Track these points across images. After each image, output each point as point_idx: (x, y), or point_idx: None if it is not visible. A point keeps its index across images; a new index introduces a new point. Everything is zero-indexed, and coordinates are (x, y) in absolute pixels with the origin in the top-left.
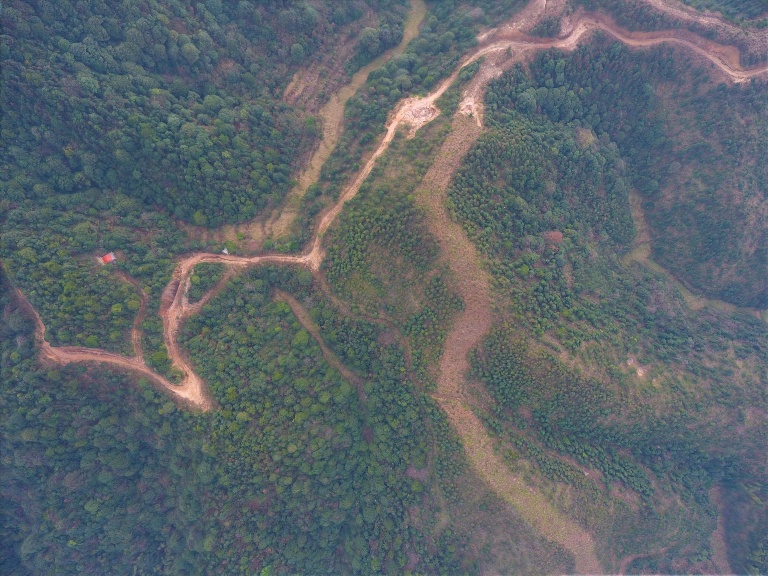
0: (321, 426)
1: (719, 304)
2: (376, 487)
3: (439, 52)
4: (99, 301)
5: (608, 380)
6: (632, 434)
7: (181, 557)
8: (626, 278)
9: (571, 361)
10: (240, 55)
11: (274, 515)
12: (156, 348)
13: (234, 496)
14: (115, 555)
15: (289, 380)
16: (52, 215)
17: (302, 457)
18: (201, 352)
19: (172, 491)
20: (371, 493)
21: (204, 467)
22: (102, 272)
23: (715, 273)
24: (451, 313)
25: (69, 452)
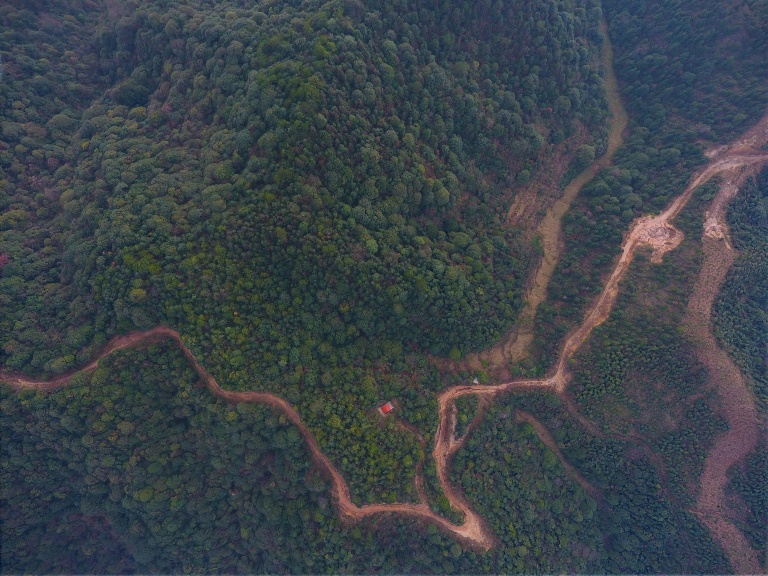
0: (577, 545)
1: None
2: None
3: (662, 167)
4: (394, 457)
5: None
6: None
7: None
8: None
9: None
10: (476, 188)
11: None
12: (437, 492)
13: None
14: None
15: (548, 504)
16: (340, 375)
17: None
18: (474, 489)
19: None
20: None
21: None
22: (390, 426)
23: None
24: (715, 434)
25: None
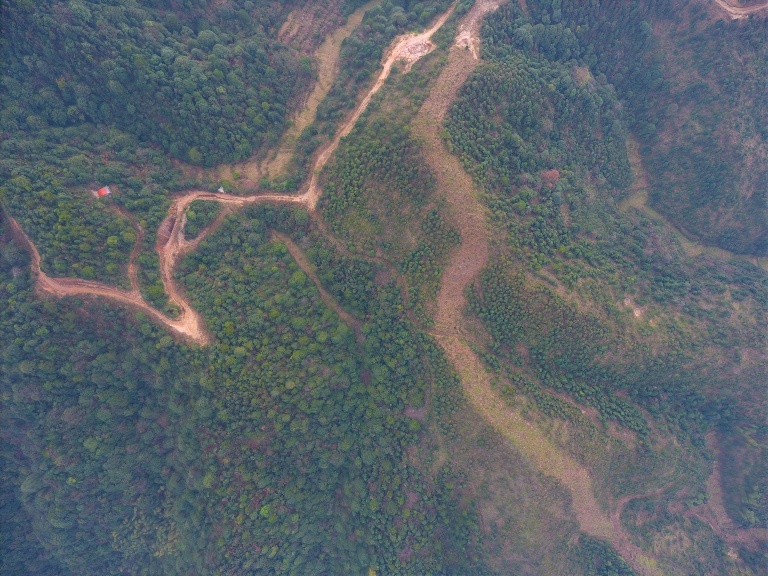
0: (319, 365)
1: (716, 251)
2: (374, 428)
3: None
4: (95, 232)
5: (605, 316)
6: (629, 374)
7: (181, 498)
8: (623, 222)
9: (568, 295)
10: None
11: (273, 454)
12: (153, 282)
13: (233, 433)
14: (115, 496)
15: (286, 318)
16: (46, 146)
17: (300, 395)
18: (198, 288)
19: (171, 431)
20: (369, 435)
21: (202, 401)
22: (97, 204)
23: (712, 218)
24: (448, 247)
25: (67, 387)
